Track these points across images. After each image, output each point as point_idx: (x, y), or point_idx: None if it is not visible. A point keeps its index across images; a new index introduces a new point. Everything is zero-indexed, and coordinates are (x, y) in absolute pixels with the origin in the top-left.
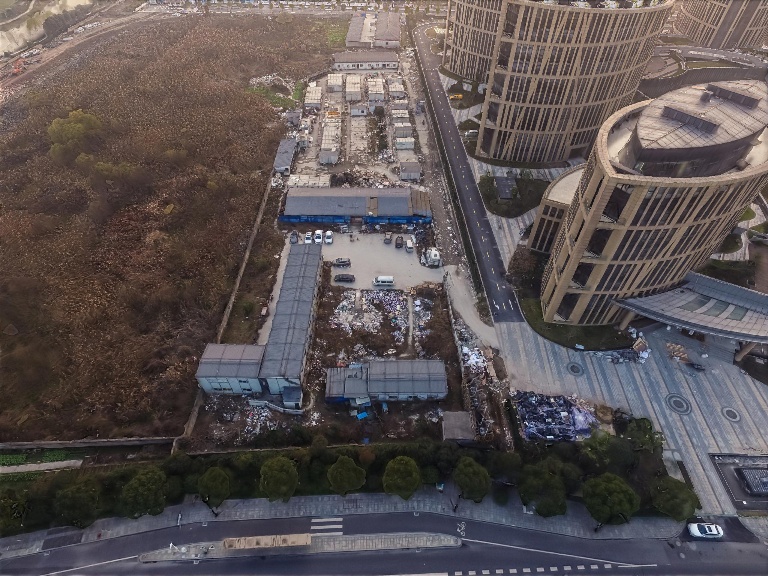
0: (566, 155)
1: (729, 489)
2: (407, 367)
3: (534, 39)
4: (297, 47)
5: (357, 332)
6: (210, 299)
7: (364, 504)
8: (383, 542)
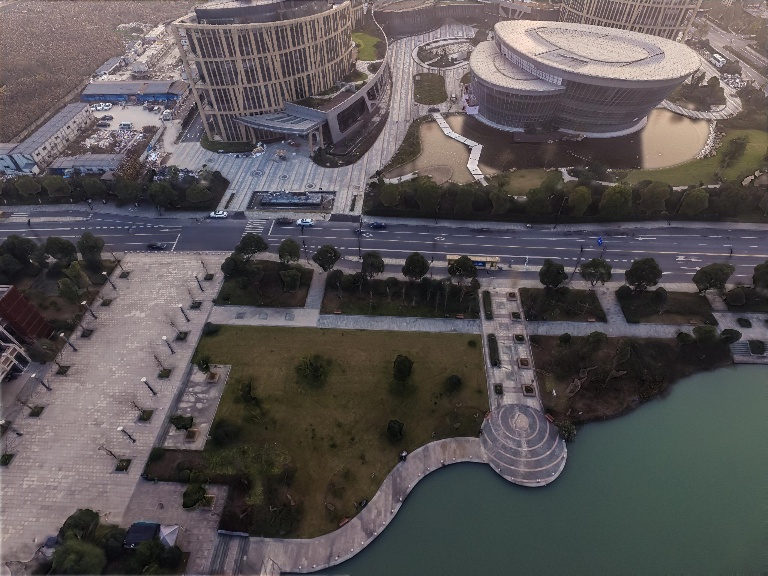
0: None
1: (252, 203)
2: (103, 156)
3: None
4: (169, 4)
5: (90, 146)
6: (9, 132)
7: (45, 208)
8: (45, 219)
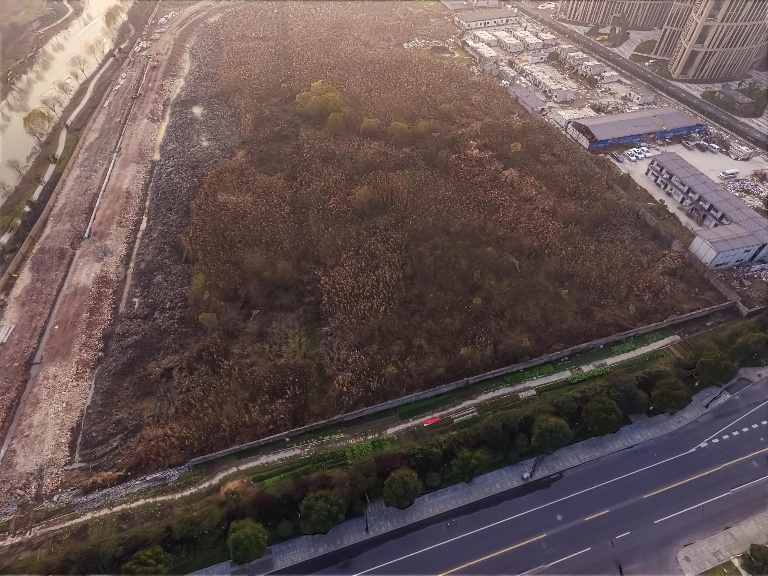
0: (748, 68)
1: None
2: None
3: None
4: (409, 14)
5: (758, 210)
6: (625, 208)
7: None
8: None
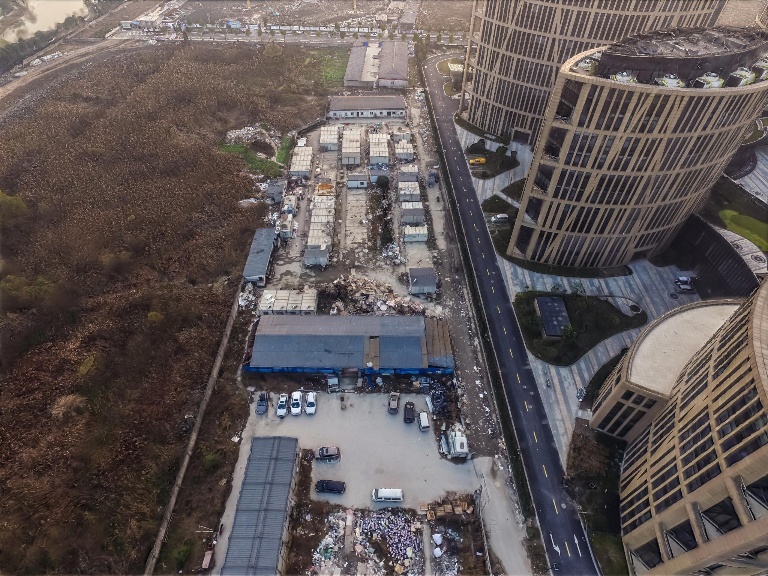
0: (627, 259)
1: None
2: None
3: (600, 127)
4: (286, 87)
5: None
6: (126, 540)
7: None
8: None
